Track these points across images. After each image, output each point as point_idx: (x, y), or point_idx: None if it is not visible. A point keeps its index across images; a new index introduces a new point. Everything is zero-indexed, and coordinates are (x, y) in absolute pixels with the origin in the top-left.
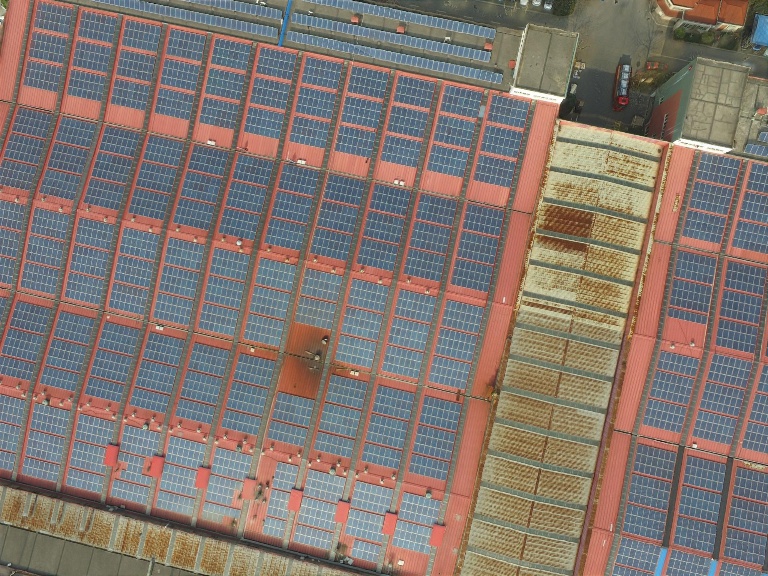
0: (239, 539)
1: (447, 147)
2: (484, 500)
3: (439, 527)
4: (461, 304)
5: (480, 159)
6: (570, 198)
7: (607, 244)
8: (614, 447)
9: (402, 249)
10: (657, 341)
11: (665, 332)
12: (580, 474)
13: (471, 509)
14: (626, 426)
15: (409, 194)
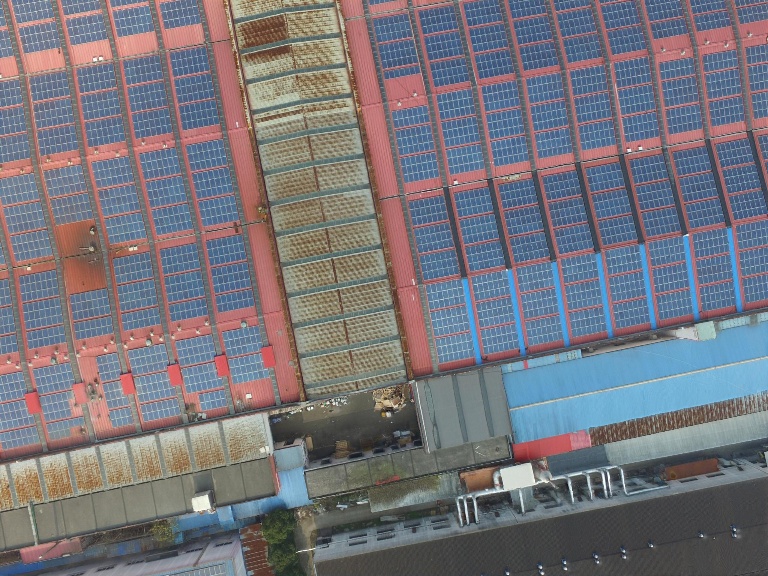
0: (94, 443)
1: (127, 8)
2: (297, 308)
3: (266, 348)
4: (200, 144)
5: (162, 7)
6: (258, 10)
7: (307, 38)
8: (389, 213)
9: (126, 118)
10: (384, 105)
11: (388, 94)
12: (369, 249)
13: (285, 319)
14: (392, 191)
15: (112, 66)
